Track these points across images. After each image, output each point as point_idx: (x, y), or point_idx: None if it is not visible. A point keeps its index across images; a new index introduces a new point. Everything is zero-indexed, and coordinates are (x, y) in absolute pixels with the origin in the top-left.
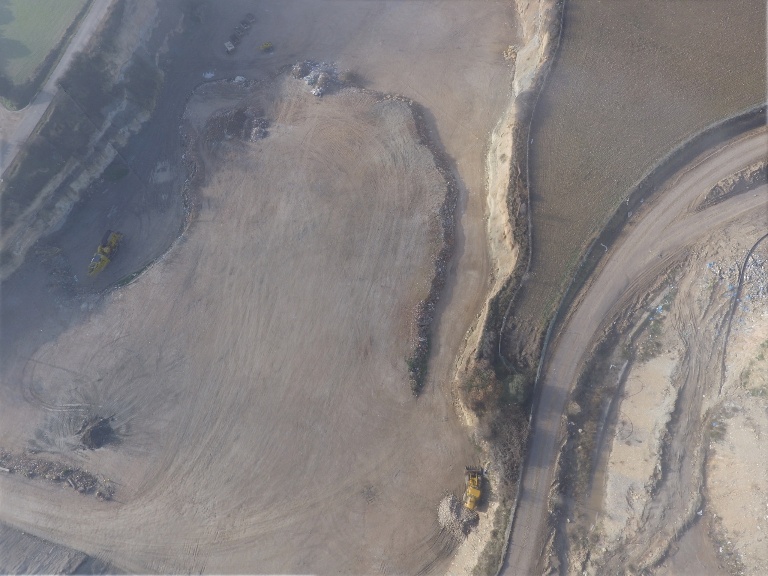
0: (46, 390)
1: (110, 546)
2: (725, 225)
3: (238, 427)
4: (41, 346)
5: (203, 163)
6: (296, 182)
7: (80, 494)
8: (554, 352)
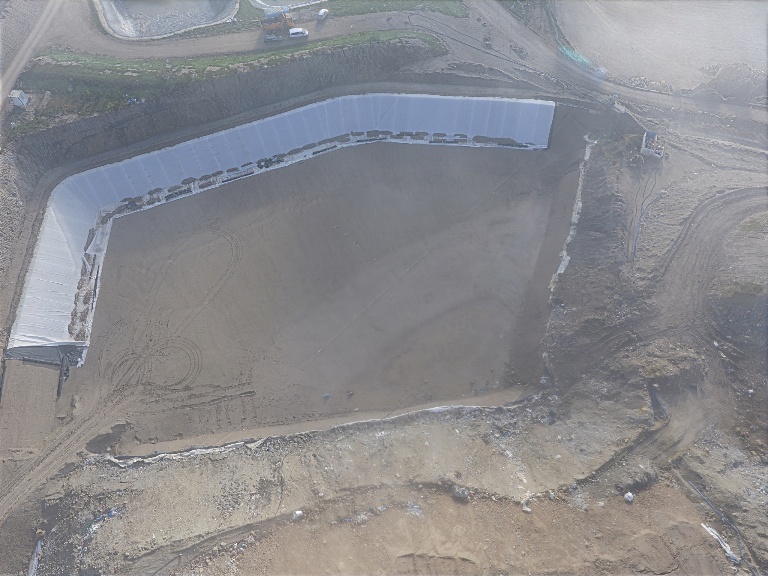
0: None
1: None
2: None
3: None
4: None
5: None
6: None
7: None
8: None
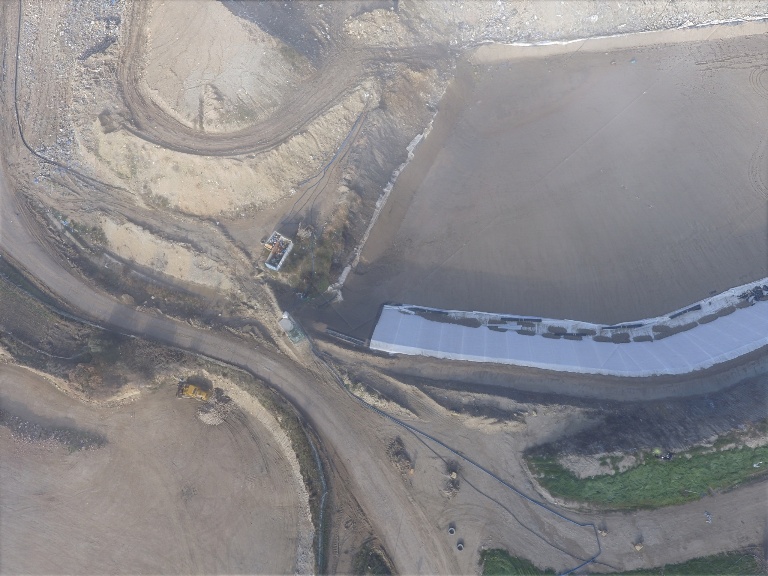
0: None
1: None
2: (5, 164)
3: None
4: None
5: None
6: None
7: None
8: (81, 311)
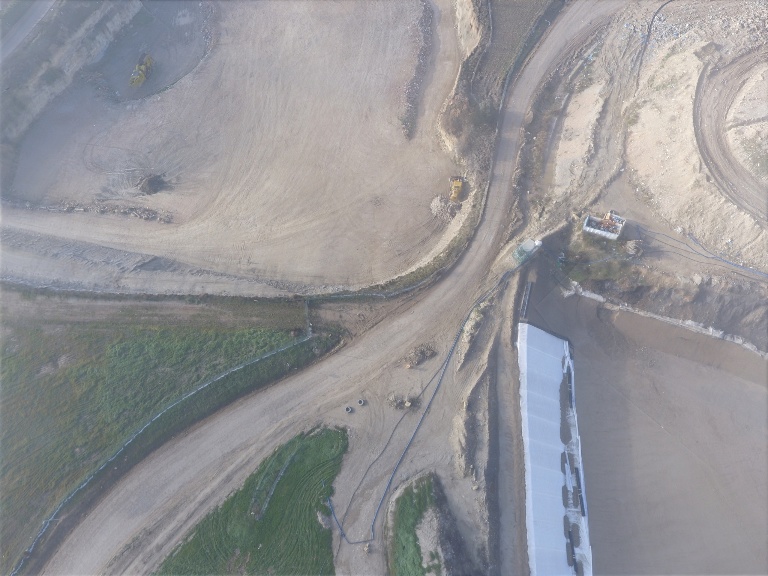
0: (105, 162)
1: (174, 250)
2: None
3: (268, 171)
4: (96, 135)
5: (218, 6)
6: (299, 12)
7: (144, 221)
8: (513, 91)
